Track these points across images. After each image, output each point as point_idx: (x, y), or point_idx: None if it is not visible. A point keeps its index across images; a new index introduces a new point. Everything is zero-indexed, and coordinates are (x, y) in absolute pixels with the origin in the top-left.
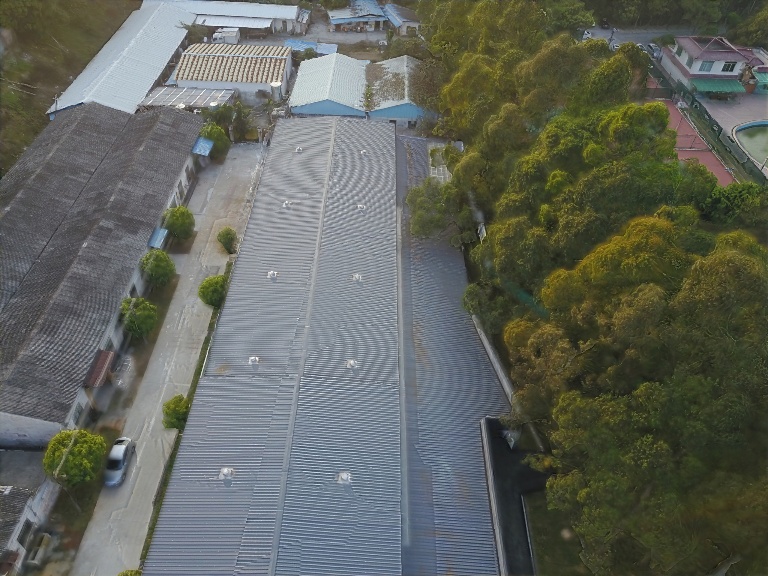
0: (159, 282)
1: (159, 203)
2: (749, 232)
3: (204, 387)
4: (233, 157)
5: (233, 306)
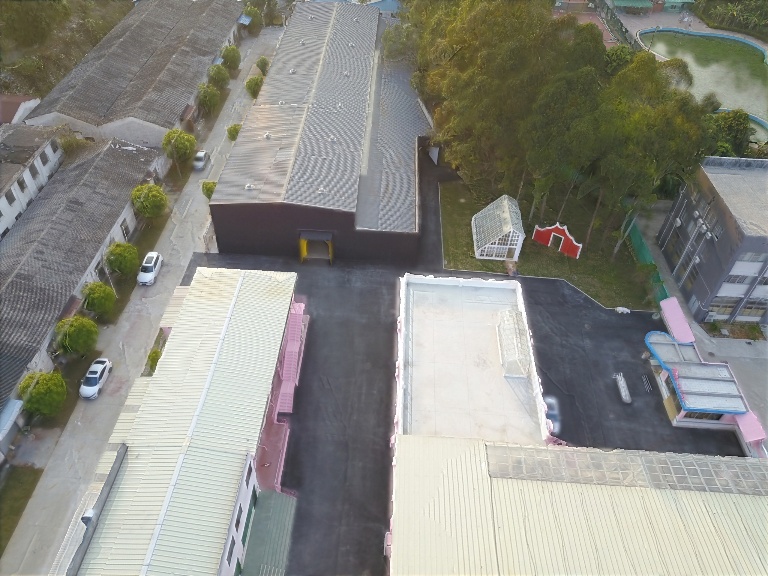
0: (219, 85)
1: (218, 44)
2: None
3: (253, 109)
4: (264, 34)
5: (269, 84)
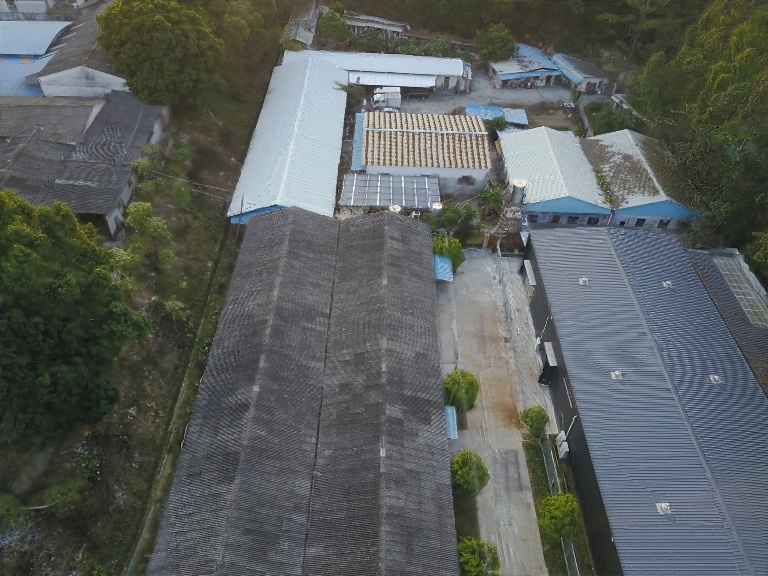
0: (471, 495)
1: (435, 366)
2: None
3: None
4: (459, 270)
5: (637, 570)
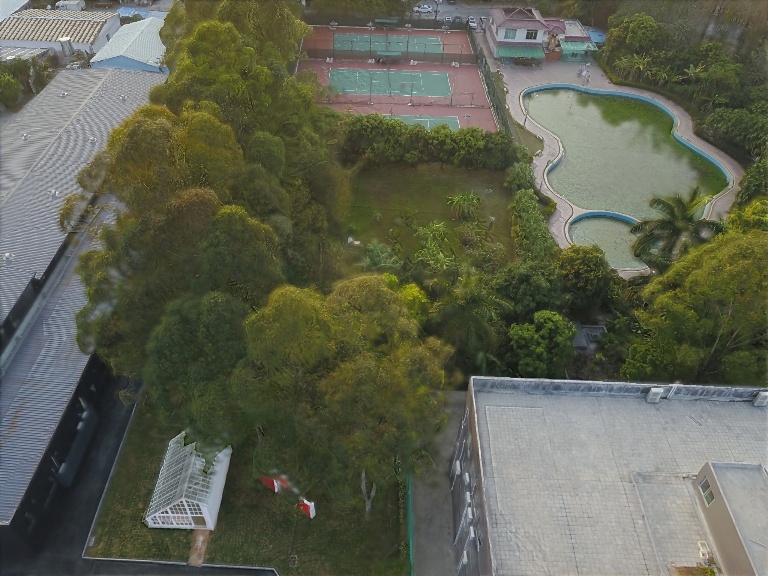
0: None
1: None
2: (486, 175)
3: None
4: None
5: None
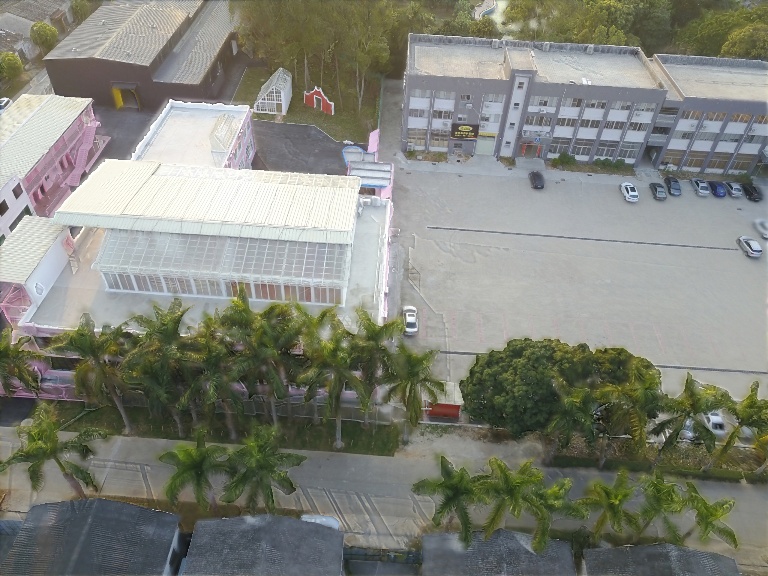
0: (94, 1)
1: None
2: (443, 13)
3: None
4: None
5: None
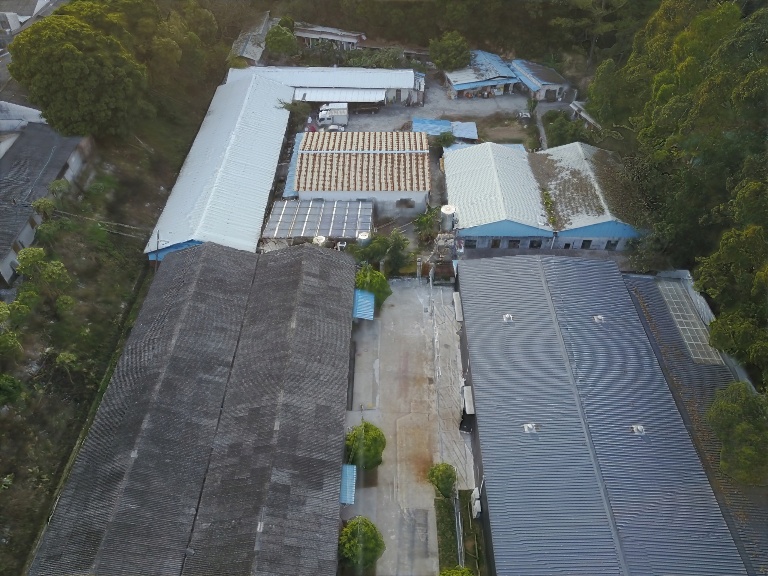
0: (364, 568)
1: (337, 420)
2: None
3: None
4: (389, 303)
5: None
